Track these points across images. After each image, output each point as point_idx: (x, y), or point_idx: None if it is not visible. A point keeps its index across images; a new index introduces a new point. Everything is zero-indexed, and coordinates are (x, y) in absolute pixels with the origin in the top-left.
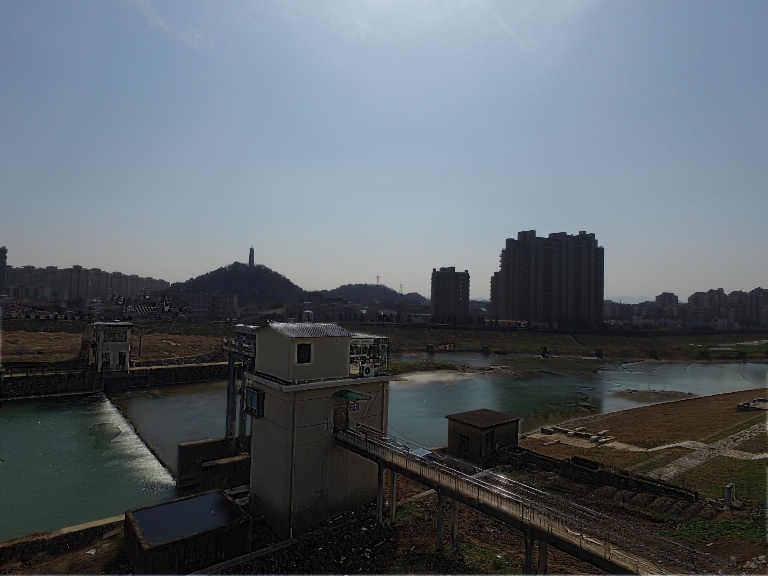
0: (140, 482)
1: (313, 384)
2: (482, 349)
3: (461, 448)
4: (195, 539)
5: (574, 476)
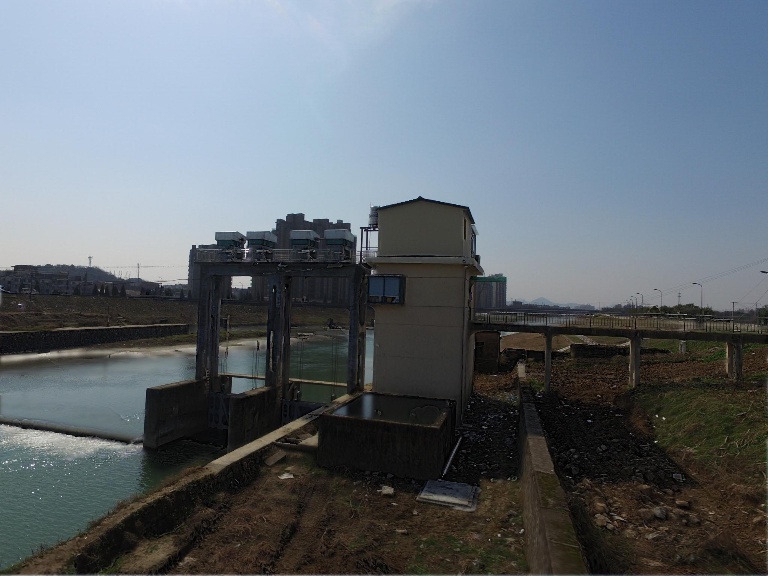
0: (72, 455)
1: None
2: None
3: None
4: None
5: (587, 354)
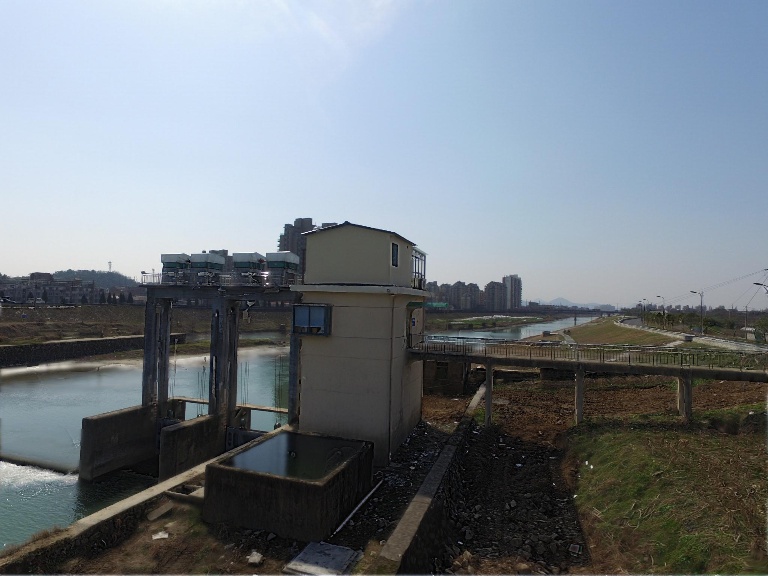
0: (4, 488)
1: (407, 289)
2: (279, 329)
3: (437, 376)
4: (348, 469)
5: (555, 377)
